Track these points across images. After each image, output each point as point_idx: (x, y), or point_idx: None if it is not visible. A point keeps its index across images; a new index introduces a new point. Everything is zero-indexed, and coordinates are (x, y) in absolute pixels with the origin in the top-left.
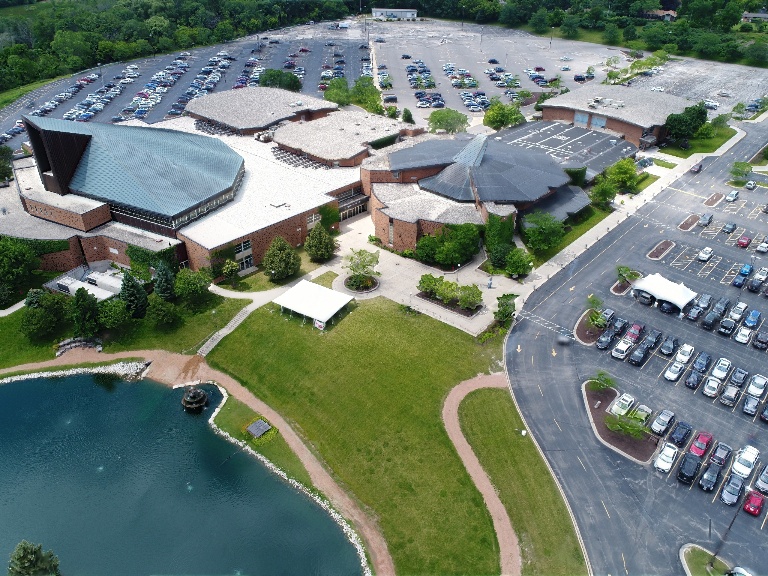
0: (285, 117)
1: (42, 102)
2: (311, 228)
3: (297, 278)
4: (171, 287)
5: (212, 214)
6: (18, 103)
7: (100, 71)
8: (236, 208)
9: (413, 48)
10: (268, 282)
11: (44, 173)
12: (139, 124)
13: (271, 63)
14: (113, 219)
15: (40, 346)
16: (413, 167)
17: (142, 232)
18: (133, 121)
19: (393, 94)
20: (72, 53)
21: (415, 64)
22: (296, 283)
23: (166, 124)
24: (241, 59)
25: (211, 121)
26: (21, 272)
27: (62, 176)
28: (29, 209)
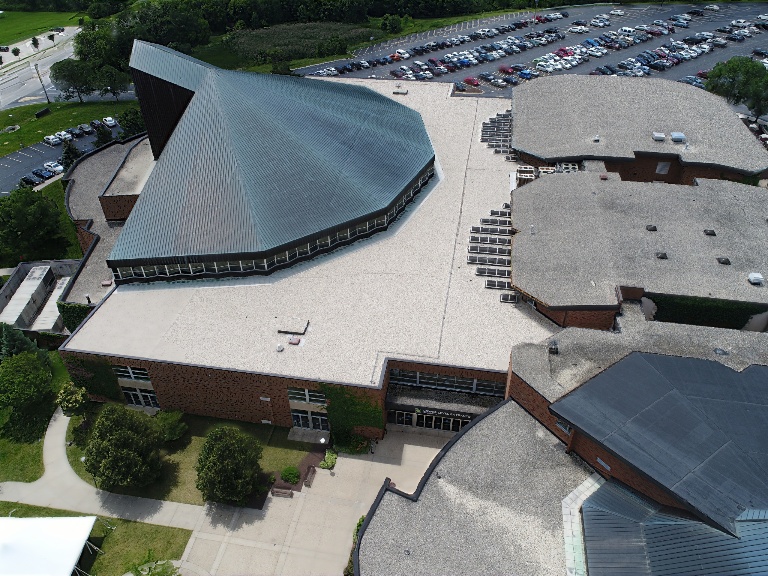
0: (603, 155)
1: (461, 34)
2: (302, 409)
3: (138, 494)
4: None
5: (200, 283)
6: (442, 30)
7: None
8: (241, 292)
9: None
10: None
11: None
12: (441, 92)
13: None
14: None
15: None
16: (602, 442)
17: None
18: (444, 85)
19: None
20: None
21: None
22: (119, 504)
23: (467, 102)
24: None
25: None
26: None
27: (155, 135)
28: None
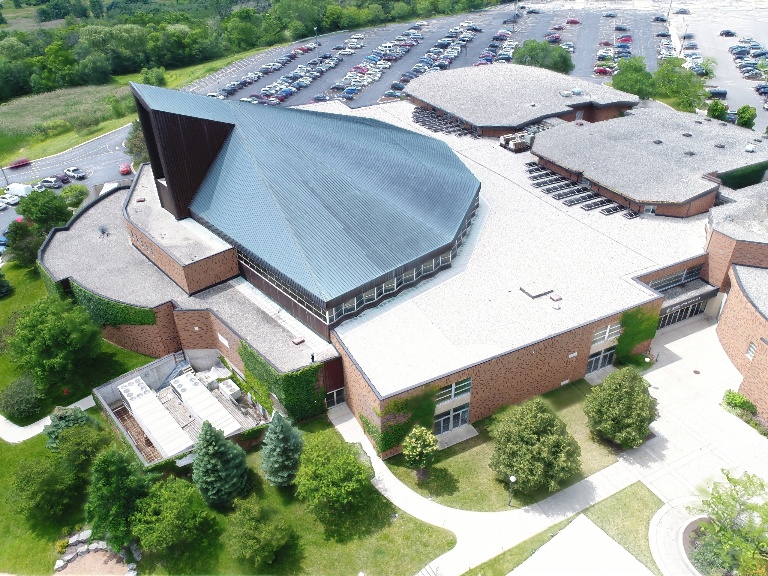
0: (554, 112)
1: (247, 72)
2: (597, 351)
3: (561, 488)
4: (292, 464)
5: (406, 295)
6: (222, 72)
7: (316, 37)
8: (453, 287)
9: (736, 22)
10: (495, 483)
11: (159, 180)
12: (338, 108)
13: (527, 37)
14: (241, 274)
15: (39, 533)
16: None
17: (277, 311)
18: (332, 103)
19: (716, 86)
20: (296, 18)
21: (743, 44)
22: (559, 505)
23: (374, 110)
24: (489, 31)
25: (437, 110)
26: (57, 366)
27: (180, 189)
28: (130, 235)
